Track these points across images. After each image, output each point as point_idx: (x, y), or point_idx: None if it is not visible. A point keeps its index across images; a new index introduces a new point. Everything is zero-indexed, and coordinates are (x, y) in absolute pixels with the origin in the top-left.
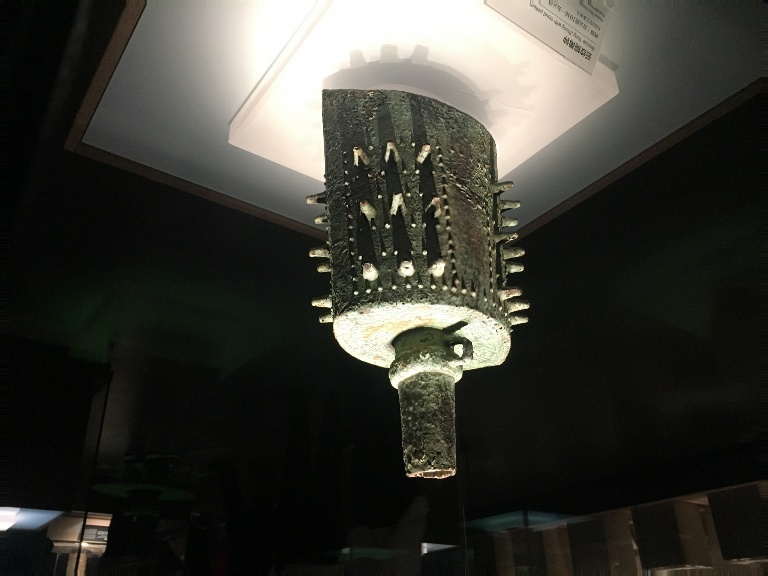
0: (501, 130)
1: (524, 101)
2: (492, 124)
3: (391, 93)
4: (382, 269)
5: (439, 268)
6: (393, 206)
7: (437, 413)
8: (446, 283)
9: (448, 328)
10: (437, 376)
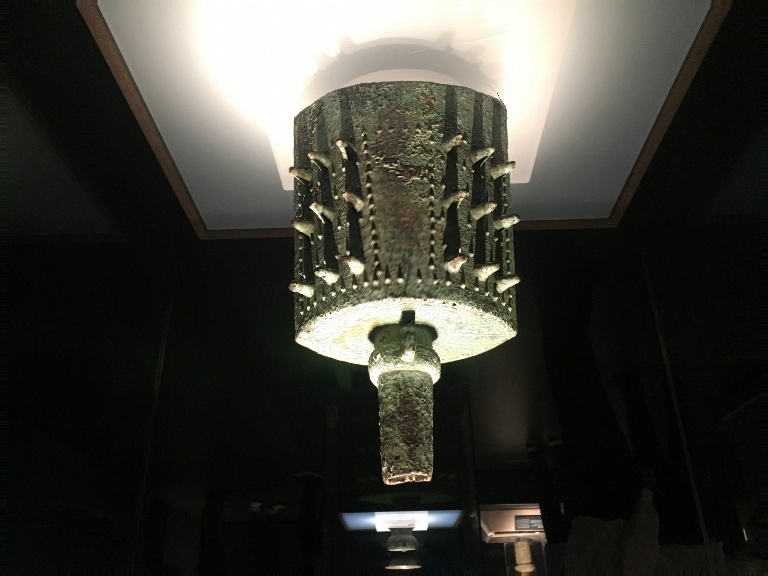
0: (494, 65)
1: (486, 27)
2: (478, 65)
3: (325, 98)
4: (316, 283)
5: (352, 267)
6: (318, 216)
7: (395, 415)
8: (367, 279)
9: (402, 320)
10: (394, 375)
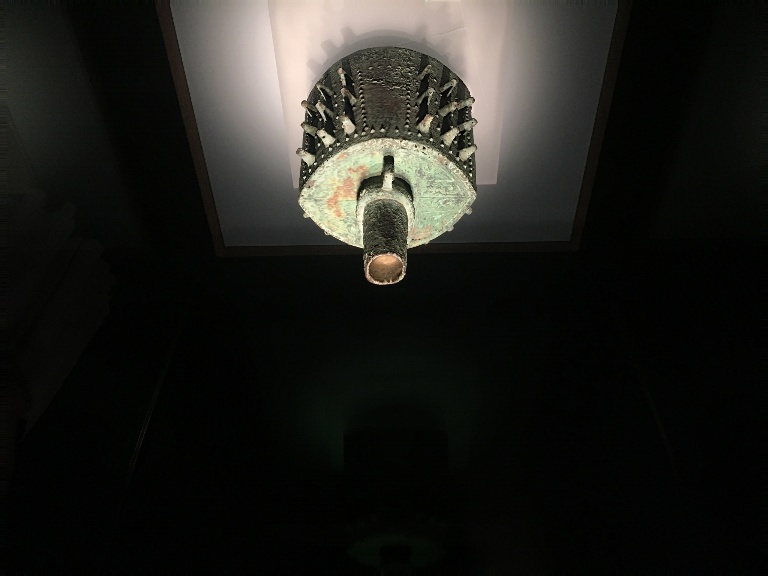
0: (459, 58)
1: (451, 22)
2: (447, 57)
3: (331, 67)
4: (317, 153)
5: (346, 125)
6: None
7: (376, 223)
8: (357, 133)
9: None
10: (376, 202)
